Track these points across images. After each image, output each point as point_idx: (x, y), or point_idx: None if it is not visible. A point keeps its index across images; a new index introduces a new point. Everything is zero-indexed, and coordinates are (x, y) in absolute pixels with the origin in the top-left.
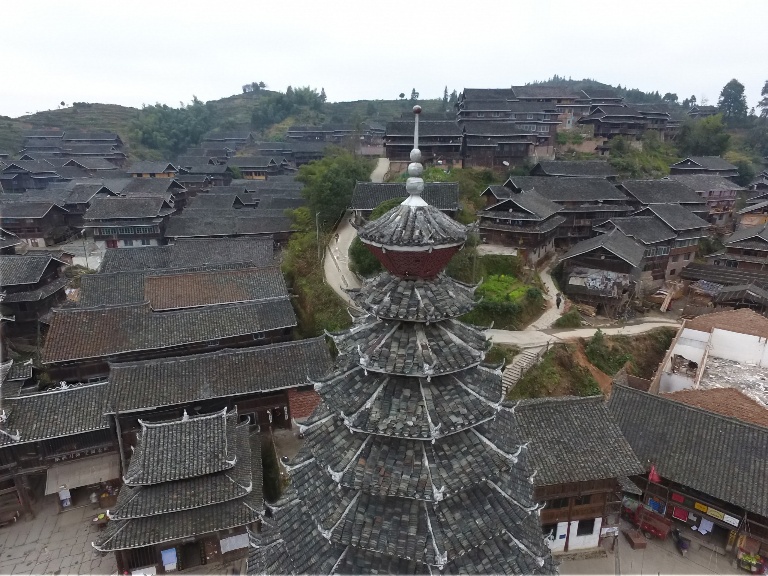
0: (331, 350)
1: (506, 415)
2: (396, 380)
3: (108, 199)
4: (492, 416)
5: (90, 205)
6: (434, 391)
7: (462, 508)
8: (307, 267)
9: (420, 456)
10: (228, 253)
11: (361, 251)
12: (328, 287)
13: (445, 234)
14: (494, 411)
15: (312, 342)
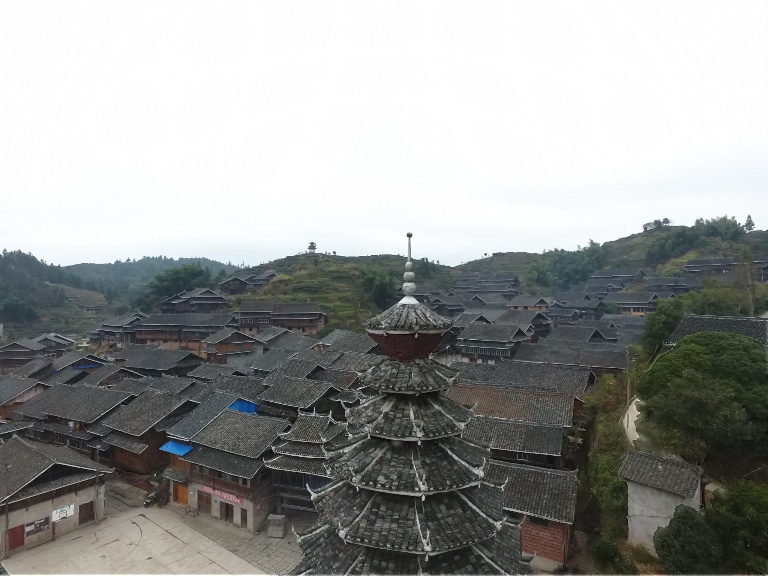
0: (596, 496)
1: (484, 524)
2: (375, 441)
3: (478, 325)
4: (417, 493)
5: (464, 329)
6: (387, 455)
7: (381, 573)
8: (615, 404)
9: (359, 504)
10: (541, 378)
11: (645, 388)
12: (620, 427)
13: (400, 323)
14: (416, 487)
15: (560, 475)
